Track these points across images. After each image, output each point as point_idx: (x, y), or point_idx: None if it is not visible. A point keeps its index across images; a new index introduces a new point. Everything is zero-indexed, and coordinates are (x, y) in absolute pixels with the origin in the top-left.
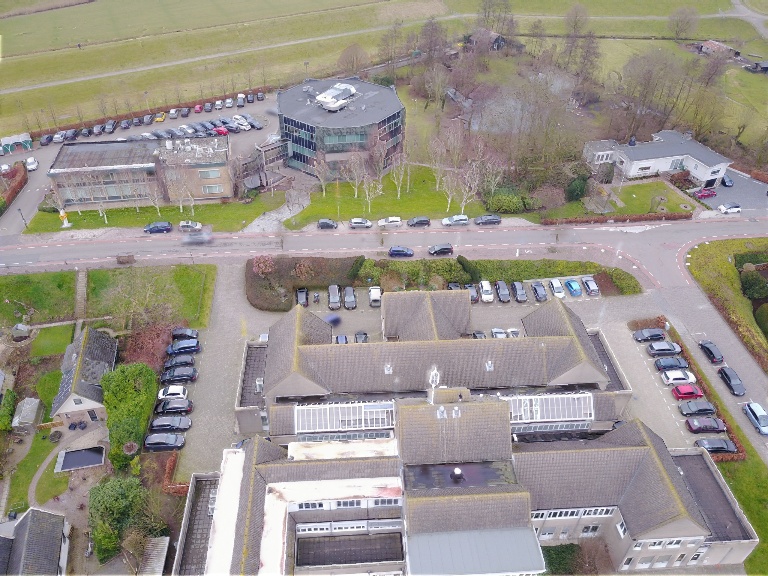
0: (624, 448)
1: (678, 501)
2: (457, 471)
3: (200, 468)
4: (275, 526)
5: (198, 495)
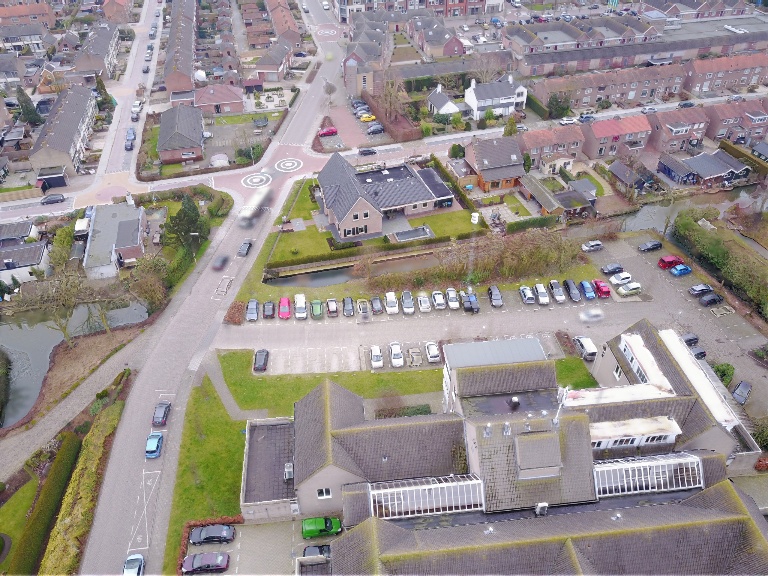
0: (356, 429)
1: (327, 387)
2: (516, 398)
3: (767, 490)
4: (650, 368)
5: (741, 441)
